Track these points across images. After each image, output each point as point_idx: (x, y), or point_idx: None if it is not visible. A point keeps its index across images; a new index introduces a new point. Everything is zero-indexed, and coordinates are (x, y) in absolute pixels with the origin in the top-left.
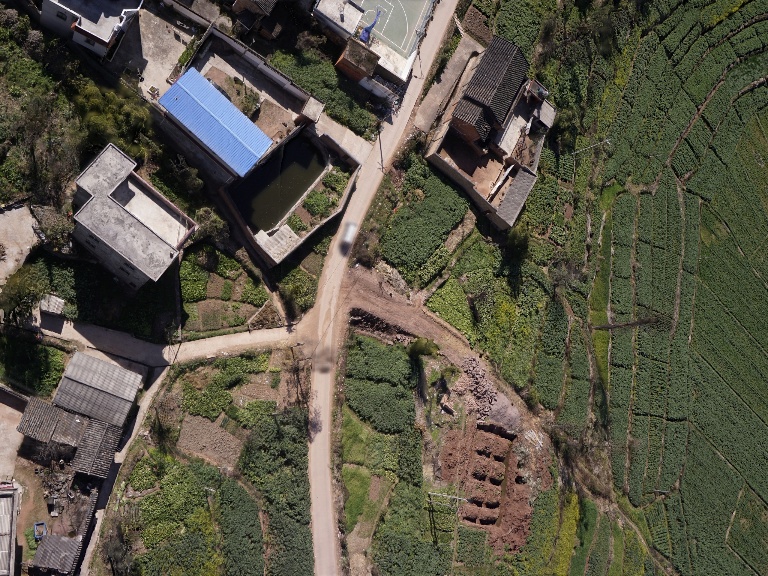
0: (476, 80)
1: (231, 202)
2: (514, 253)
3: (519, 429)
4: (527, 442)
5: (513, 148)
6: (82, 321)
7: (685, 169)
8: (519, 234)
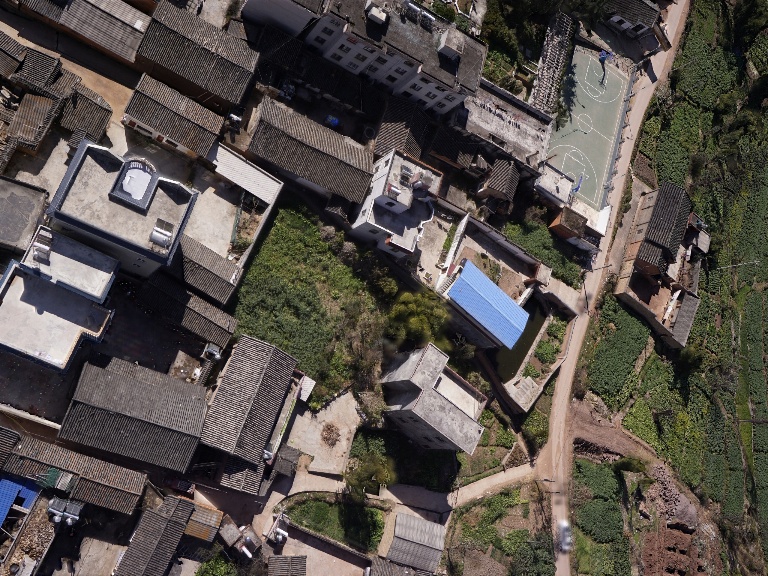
0: (654, 224)
1: (489, 363)
2: (684, 368)
3: (697, 524)
4: (703, 534)
5: (677, 274)
6: (393, 482)
7: None
8: (693, 355)
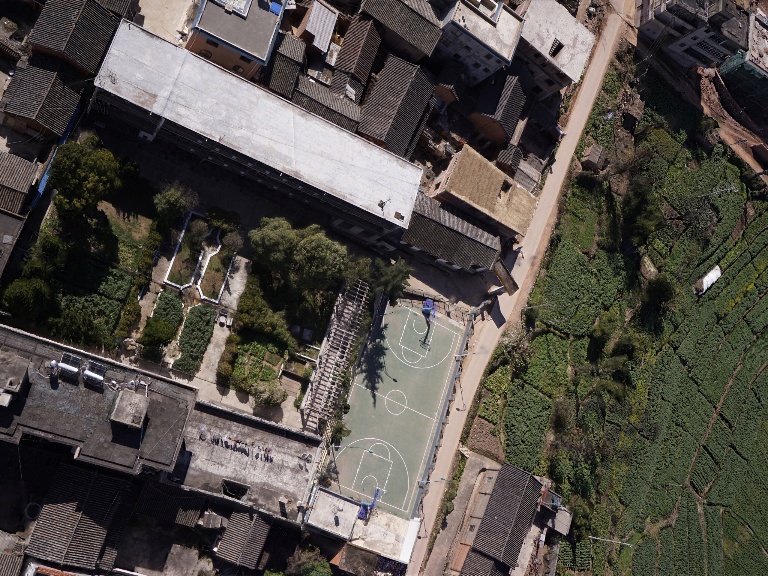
0: (486, 526)
1: None
2: None
3: None
4: None
5: (526, 565)
6: None
7: (705, 482)
8: None
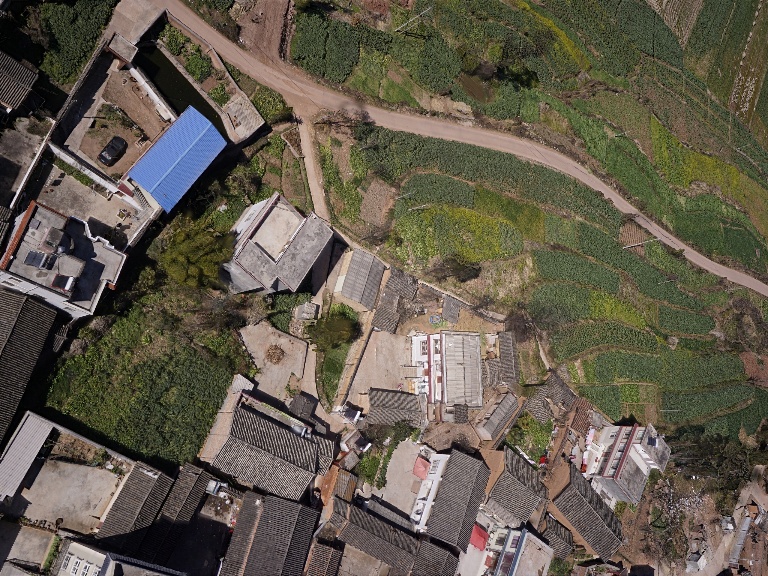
0: None
1: None
2: None
3: None
4: None
5: None
6: (312, 290)
7: None
8: None
